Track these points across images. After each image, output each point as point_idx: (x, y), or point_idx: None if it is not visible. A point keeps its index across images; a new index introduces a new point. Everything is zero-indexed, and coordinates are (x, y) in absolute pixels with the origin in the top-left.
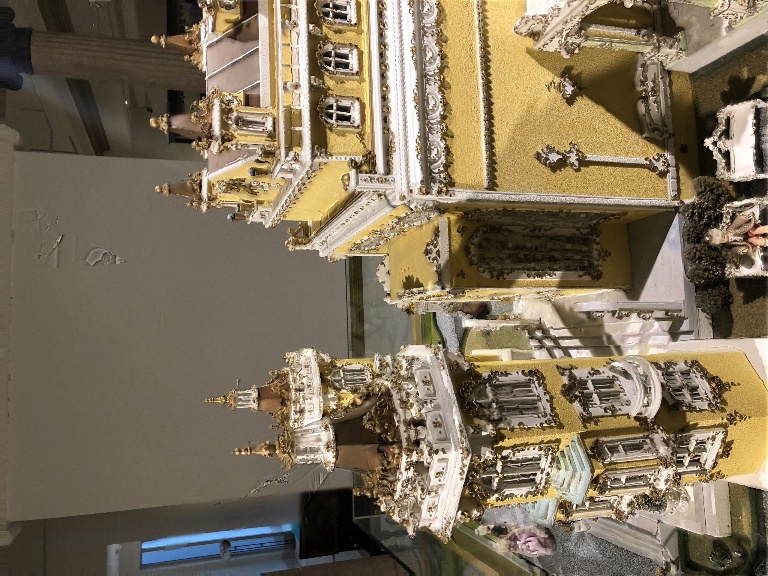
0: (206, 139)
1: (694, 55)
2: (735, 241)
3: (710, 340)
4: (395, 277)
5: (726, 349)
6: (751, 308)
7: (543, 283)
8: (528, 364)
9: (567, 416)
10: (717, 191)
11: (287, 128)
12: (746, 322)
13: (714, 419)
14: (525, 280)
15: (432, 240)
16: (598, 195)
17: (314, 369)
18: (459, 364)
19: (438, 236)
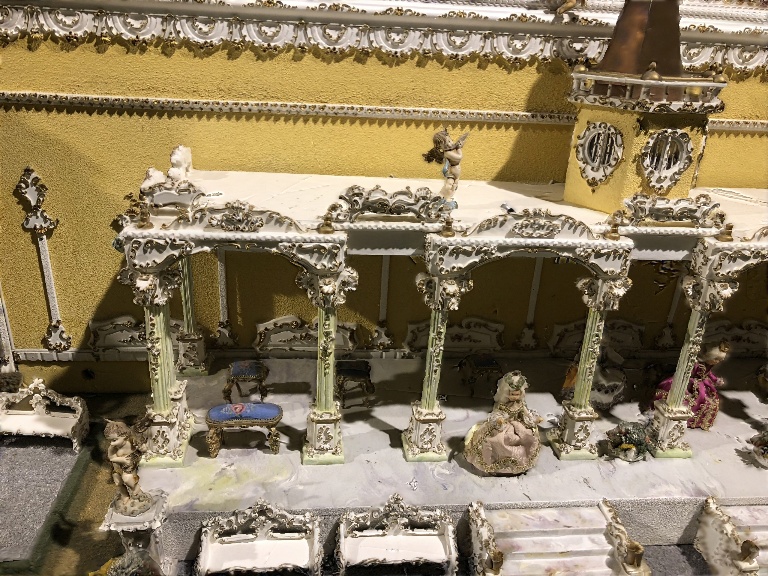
0: None
1: None
2: None
3: None
4: None
5: None
6: None
7: None
8: None
9: None
10: None
11: None
12: None
13: None
14: None
15: None
16: None
17: None
18: None
19: None
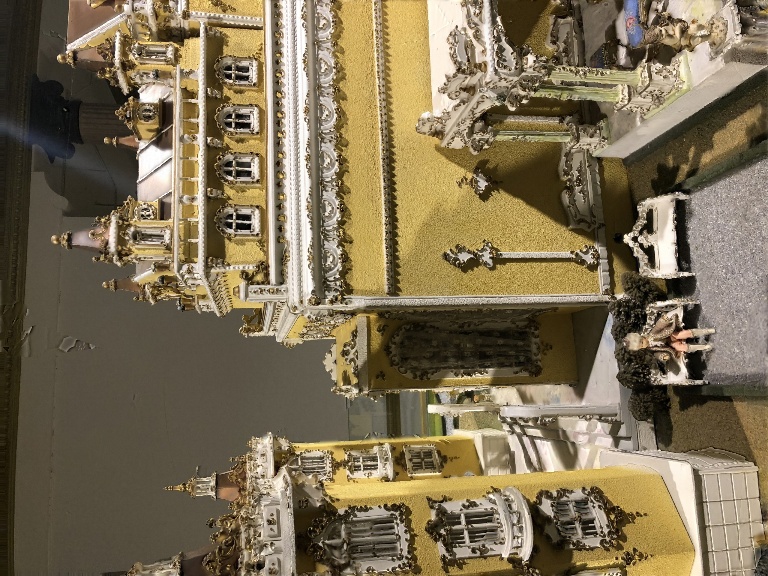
0: (104, 255)
1: (617, 143)
2: (656, 346)
3: (633, 455)
4: (339, 368)
5: (641, 470)
6: (687, 416)
7: (473, 382)
8: (394, 496)
9: (428, 558)
10: (644, 288)
11: (183, 241)
12: (683, 431)
13: (606, 559)
14: (453, 379)
15: (350, 341)
16: (516, 294)
17: (269, 458)
18: (309, 500)
19: (356, 337)
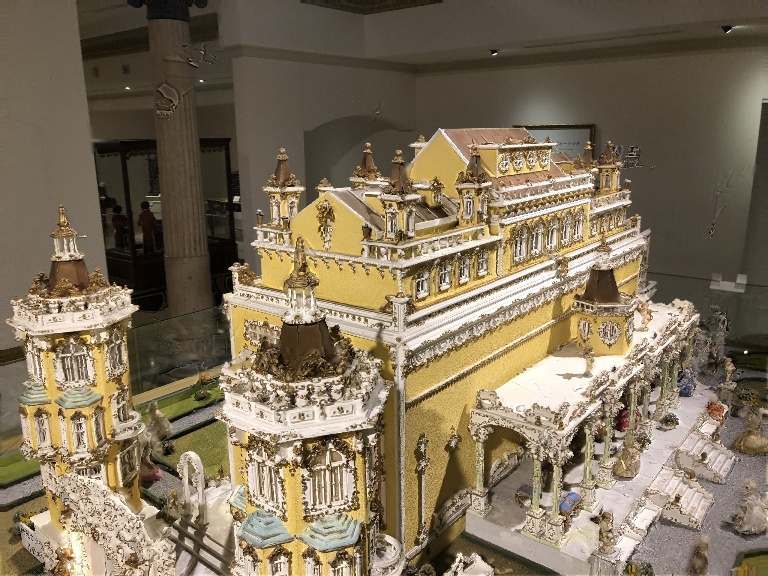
0: (399, 191)
1: (487, 522)
2: None
3: None
4: None
5: None
6: None
7: None
8: None
9: None
10: None
11: None
12: None
13: None
14: None
15: None
16: None
17: (125, 312)
18: None
19: None
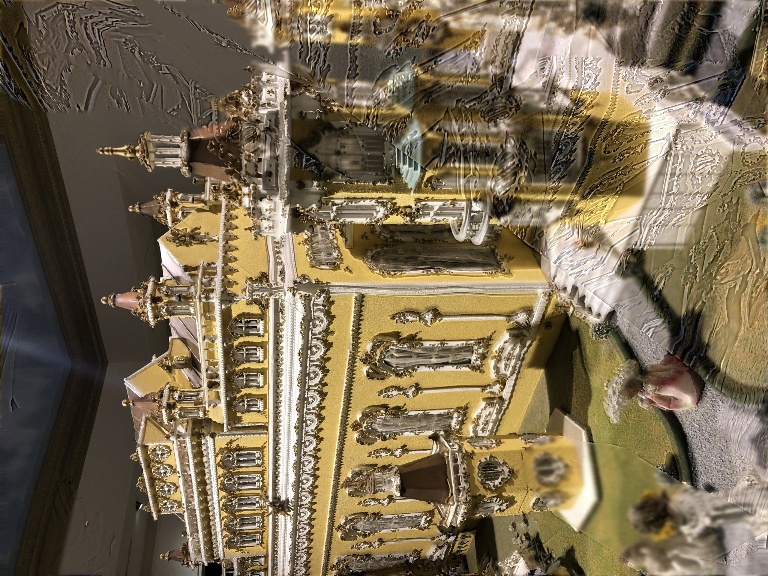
0: None
1: None
2: None
3: None
4: None
5: None
6: None
7: None
8: None
9: None
10: None
11: None
12: None
13: None
14: None
15: None
16: None
17: None
18: None
19: None
